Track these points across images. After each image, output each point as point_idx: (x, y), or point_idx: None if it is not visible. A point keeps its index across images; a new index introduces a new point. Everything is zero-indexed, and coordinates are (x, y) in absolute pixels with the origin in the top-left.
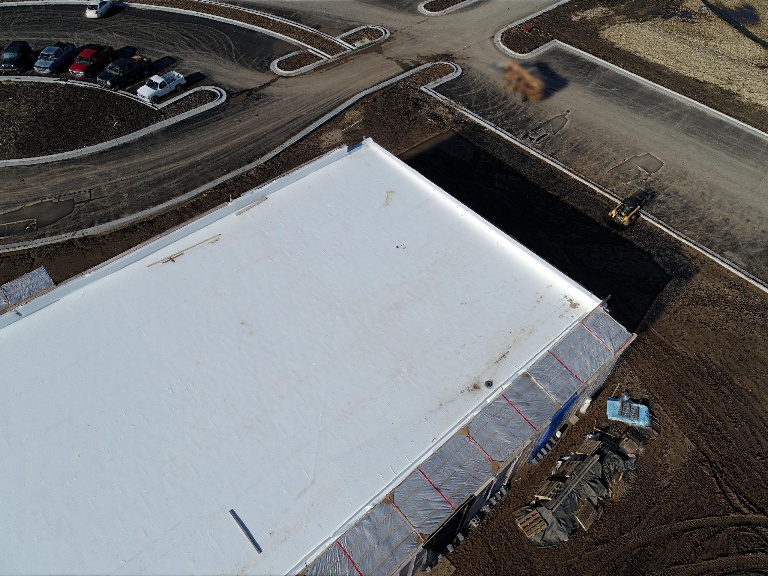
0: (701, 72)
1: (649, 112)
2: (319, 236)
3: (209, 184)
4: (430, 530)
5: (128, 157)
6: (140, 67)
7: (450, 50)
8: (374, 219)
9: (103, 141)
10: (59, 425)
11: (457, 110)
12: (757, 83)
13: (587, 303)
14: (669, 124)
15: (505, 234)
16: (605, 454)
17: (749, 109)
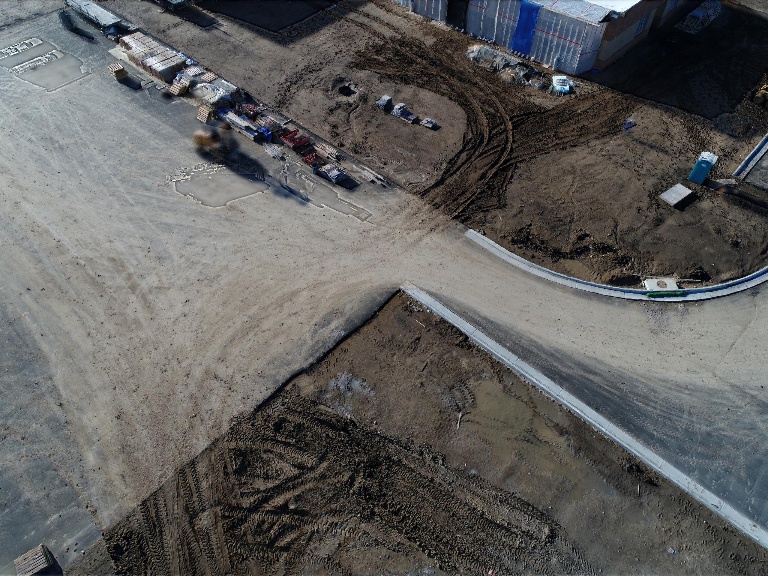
0: None
1: None
2: None
3: None
4: None
5: None
6: None
7: None
8: None
9: None
10: None
11: None
12: None
13: None
14: None
15: None
16: None
17: None
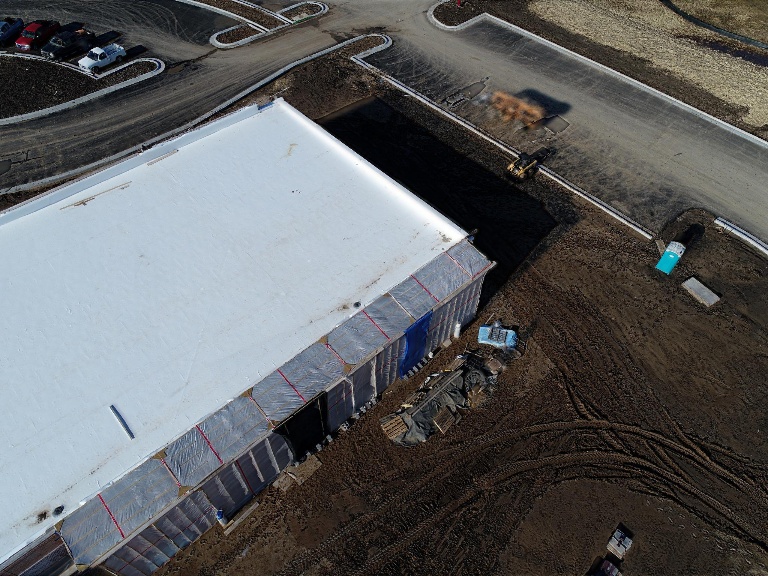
0: (618, 41)
1: (564, 78)
2: (222, 183)
3: (139, 145)
4: (281, 418)
5: (66, 122)
6: (83, 40)
7: (384, 23)
8: (275, 168)
9: (43, 108)
10: None
11: (382, 78)
12: (669, 51)
13: (457, 237)
14: (581, 89)
15: (392, 179)
16: (469, 370)
17: (658, 75)
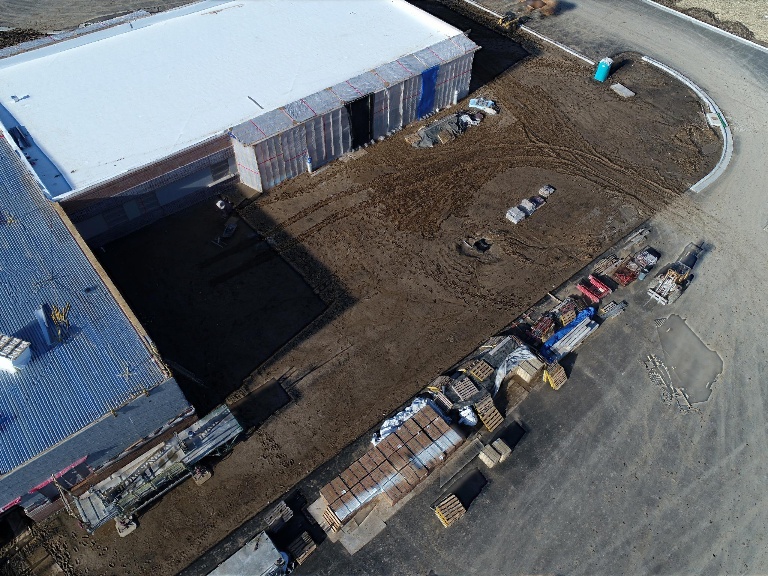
0: None
1: None
2: (303, 7)
3: None
4: (348, 100)
5: None
6: None
7: None
8: (338, 1)
9: None
10: (158, 67)
11: None
12: None
13: None
14: None
15: (416, 7)
16: None
17: None
